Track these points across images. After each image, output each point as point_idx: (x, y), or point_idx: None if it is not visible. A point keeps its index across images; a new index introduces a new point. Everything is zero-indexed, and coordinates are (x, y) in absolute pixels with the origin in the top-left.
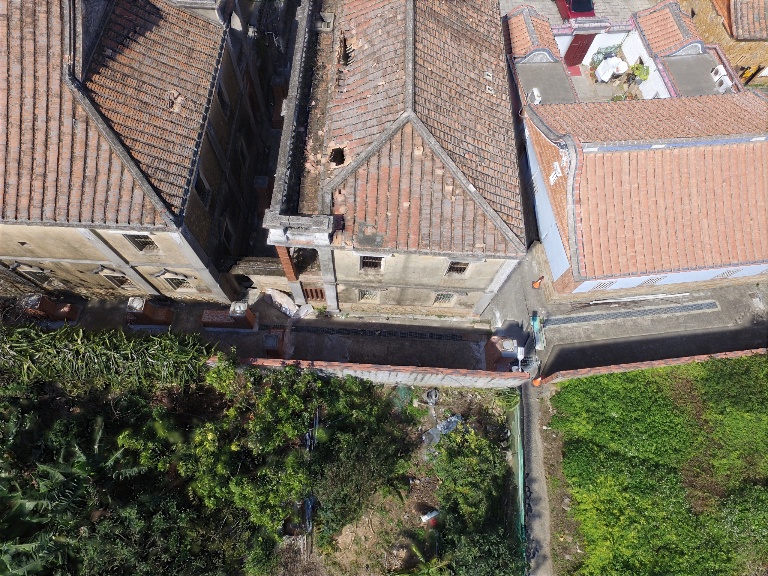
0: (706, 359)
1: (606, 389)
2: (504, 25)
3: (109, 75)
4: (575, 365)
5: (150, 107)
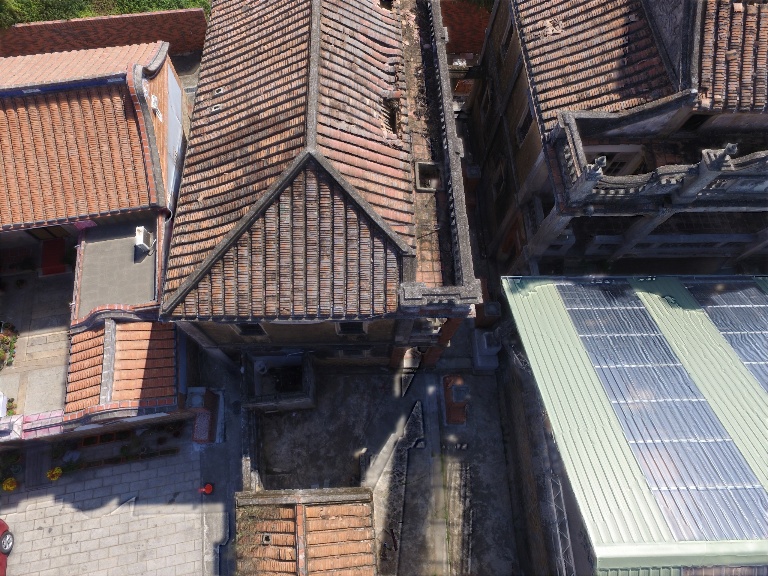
0: (73, 19)
1: (166, 7)
2: (149, 390)
3: (618, 1)
4: (180, 61)
5: (569, 4)
